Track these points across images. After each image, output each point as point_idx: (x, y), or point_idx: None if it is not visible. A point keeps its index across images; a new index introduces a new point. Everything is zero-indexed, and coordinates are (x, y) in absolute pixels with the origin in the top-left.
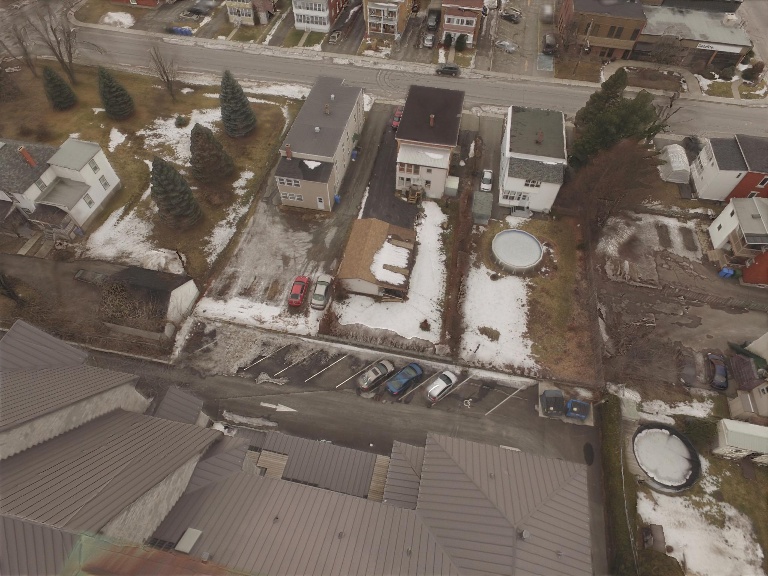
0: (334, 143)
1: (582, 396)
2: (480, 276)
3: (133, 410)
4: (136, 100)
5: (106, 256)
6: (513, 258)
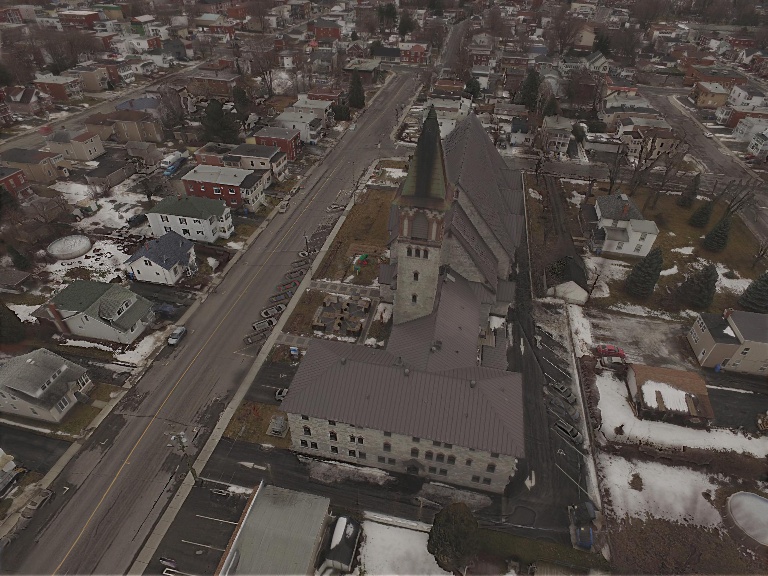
0: (764, 340)
1: (601, 550)
2: (700, 482)
3: (499, 270)
4: (732, 251)
5: (589, 265)
6: (742, 513)
